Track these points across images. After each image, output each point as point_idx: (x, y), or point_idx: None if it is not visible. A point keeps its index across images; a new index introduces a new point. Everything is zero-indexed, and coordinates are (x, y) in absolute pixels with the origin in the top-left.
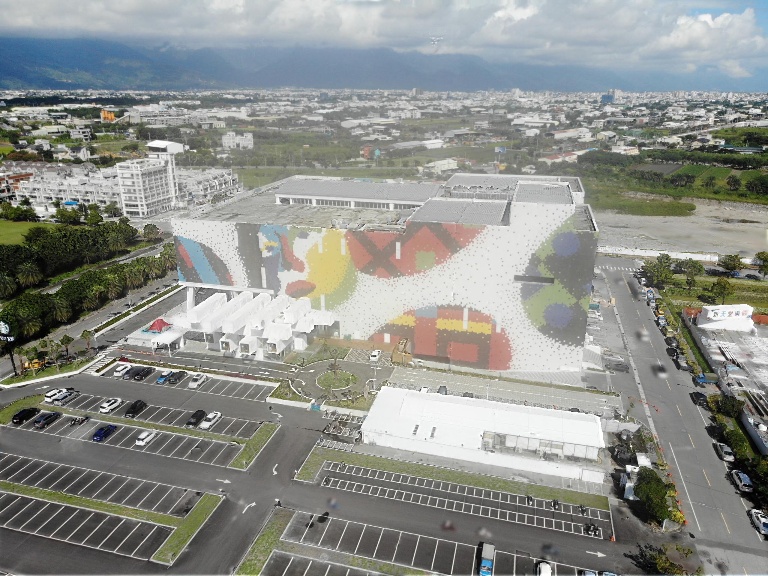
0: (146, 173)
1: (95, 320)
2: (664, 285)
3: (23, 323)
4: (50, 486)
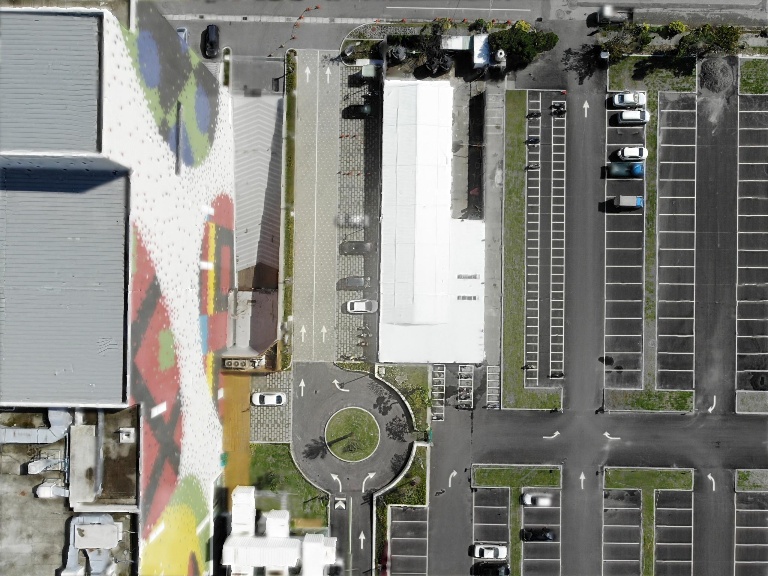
0: None
1: None
2: None
3: None
4: None
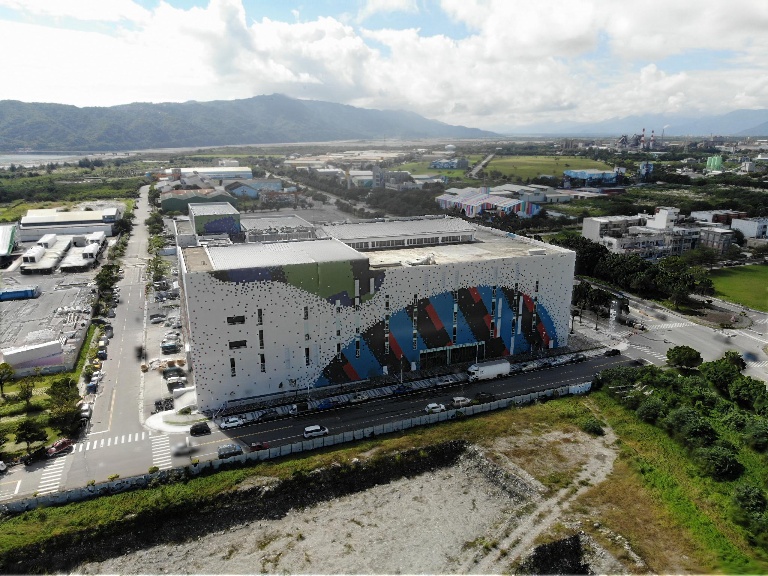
0: None
1: None
2: None
3: None
4: None
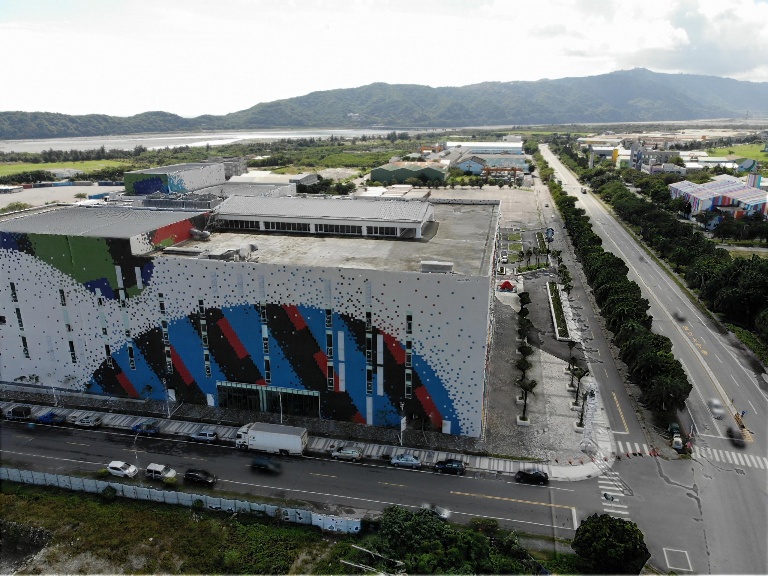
0: None
1: (578, 295)
2: None
3: None
4: None
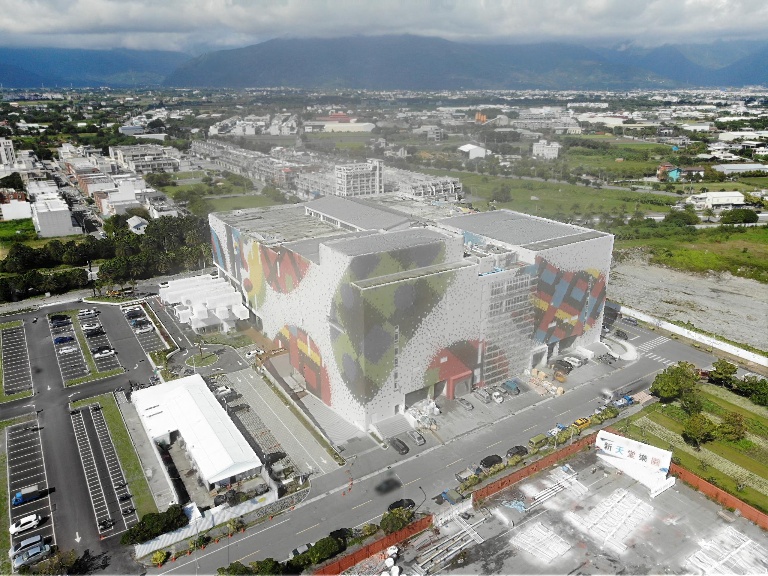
0: (352, 175)
1: (183, 276)
2: (679, 399)
3: (132, 267)
4: (6, 356)
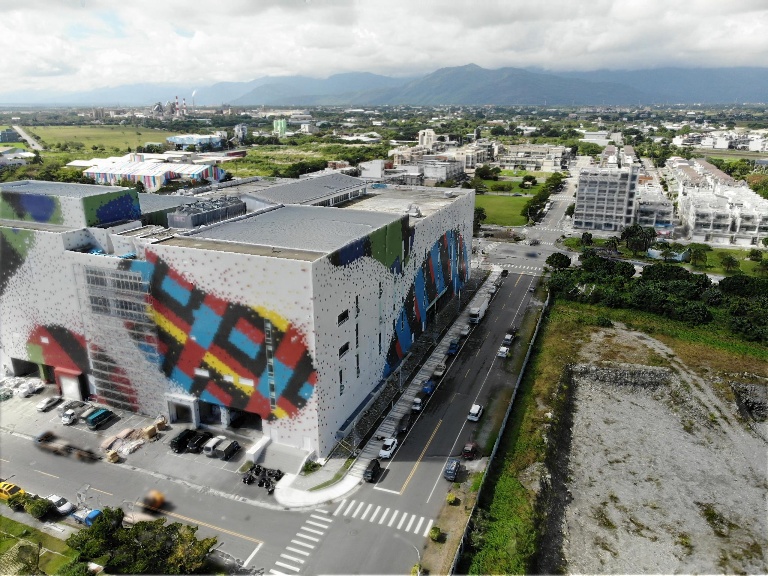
0: (588, 181)
1: None
2: None
3: None
4: None
